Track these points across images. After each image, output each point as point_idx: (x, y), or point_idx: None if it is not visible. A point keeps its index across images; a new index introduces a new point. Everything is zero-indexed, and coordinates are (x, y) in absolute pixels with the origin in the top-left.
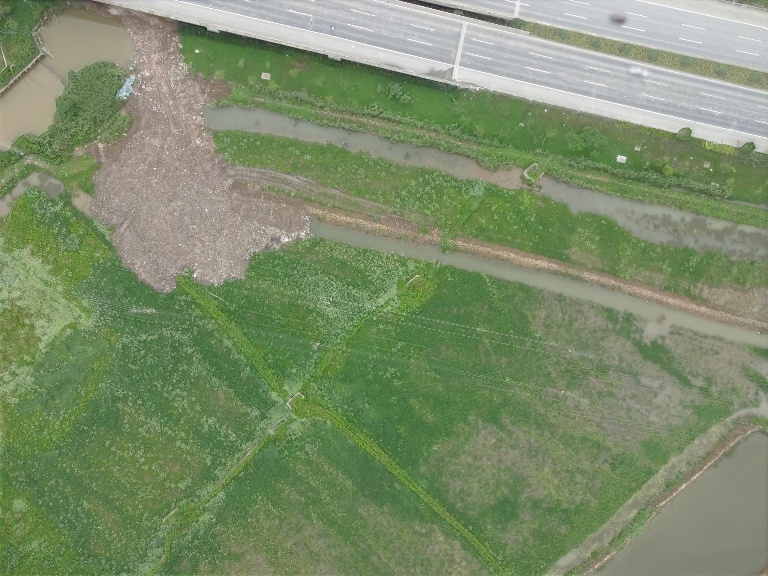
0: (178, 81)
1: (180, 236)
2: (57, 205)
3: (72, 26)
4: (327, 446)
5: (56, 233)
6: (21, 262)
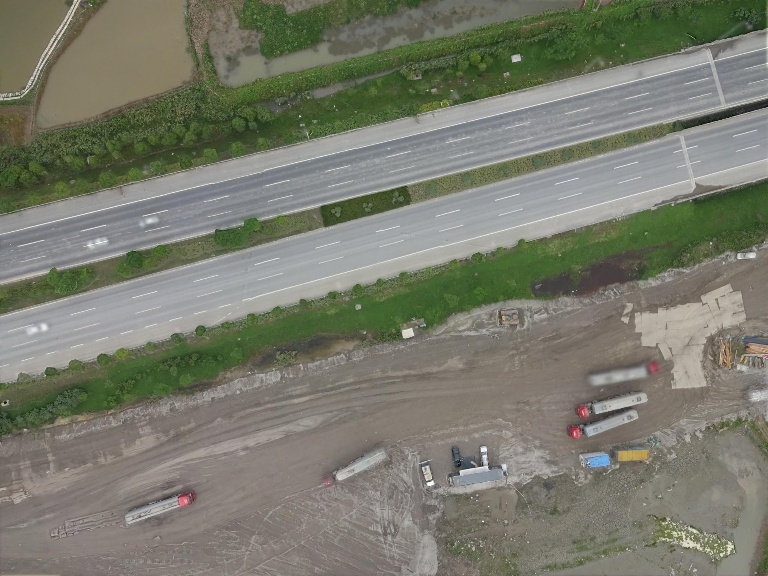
0: None
1: None
2: None
3: None
4: None
5: None
6: None
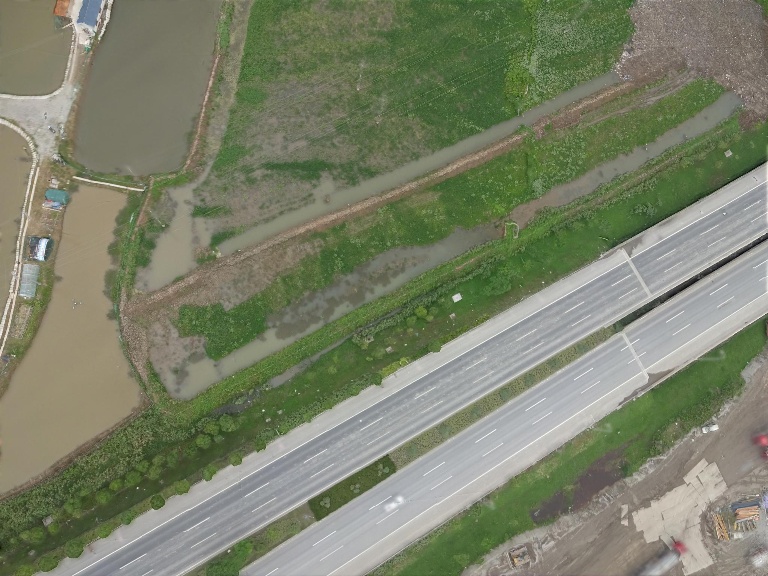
0: None
1: (685, 7)
2: None
3: None
4: None
5: None
6: None
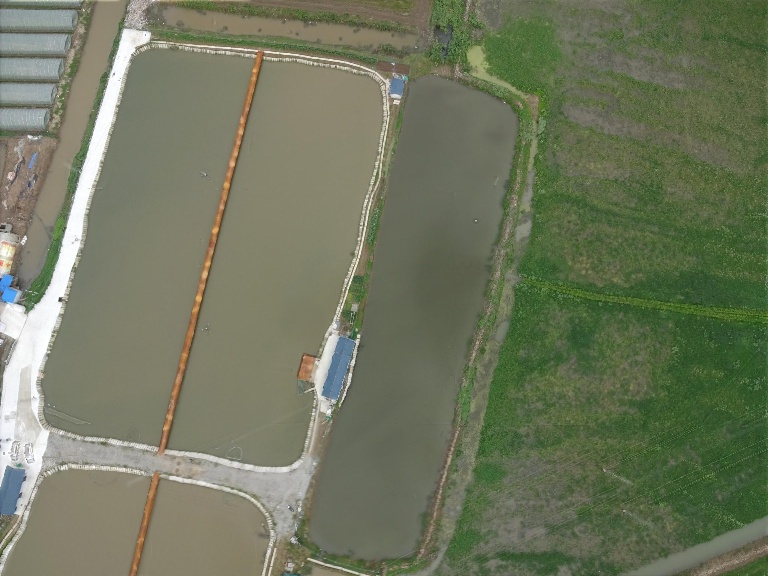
0: None
1: None
2: None
3: None
4: (759, 291)
5: None
6: None
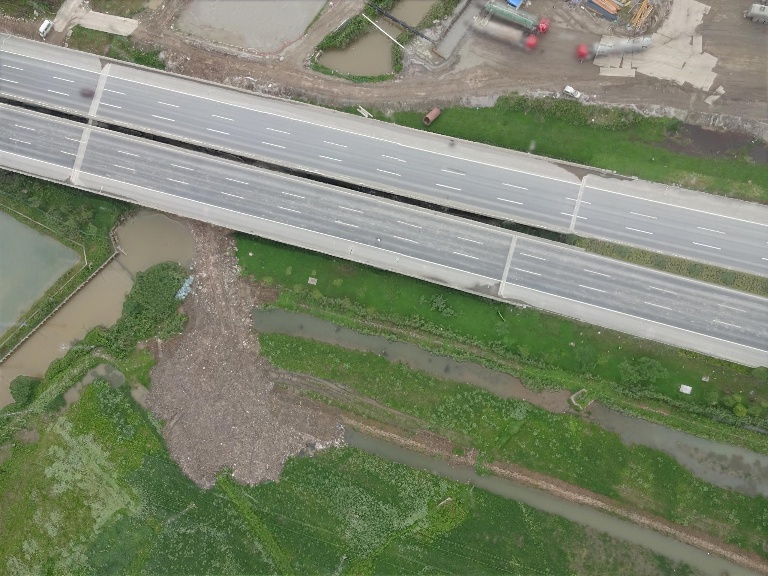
0: (231, 283)
1: (222, 435)
2: (118, 396)
3: (145, 224)
4: None
5: (115, 422)
6: (84, 447)
